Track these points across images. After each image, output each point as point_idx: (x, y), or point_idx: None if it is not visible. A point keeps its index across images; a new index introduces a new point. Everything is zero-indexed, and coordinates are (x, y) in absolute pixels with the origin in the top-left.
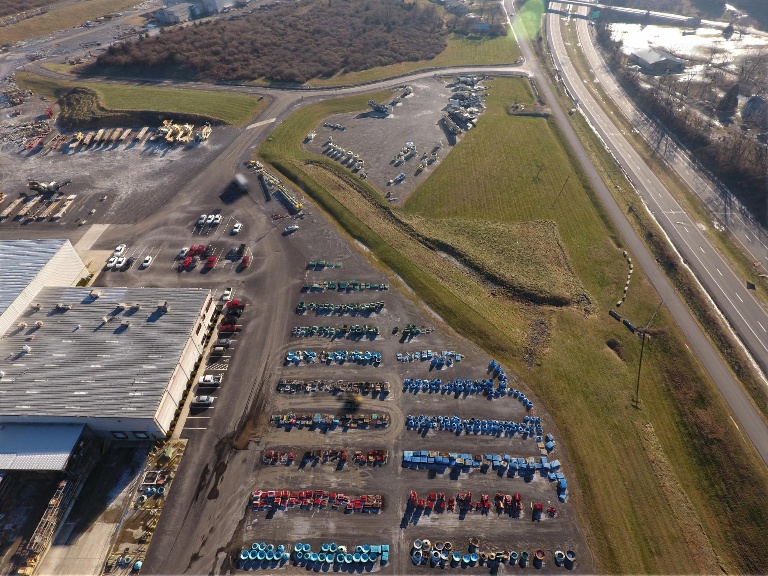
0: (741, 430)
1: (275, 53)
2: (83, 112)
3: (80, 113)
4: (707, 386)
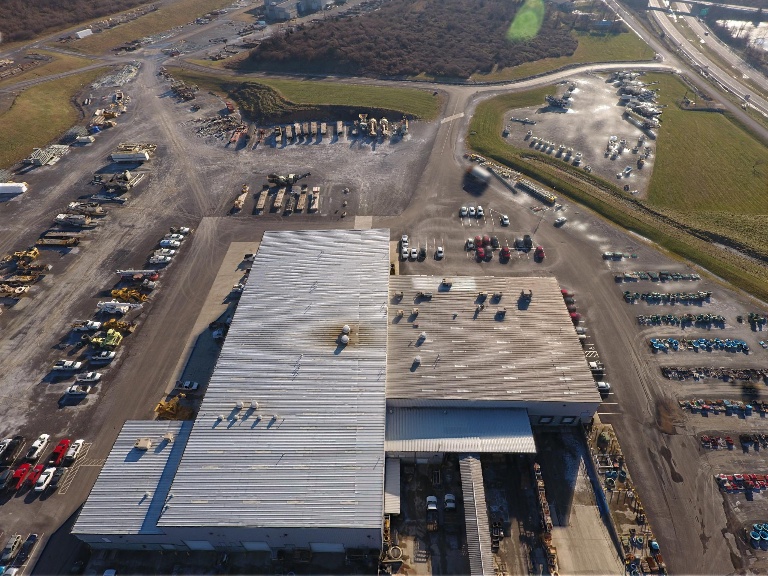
0: None
1: (424, 49)
2: (270, 106)
3: (268, 107)
4: None
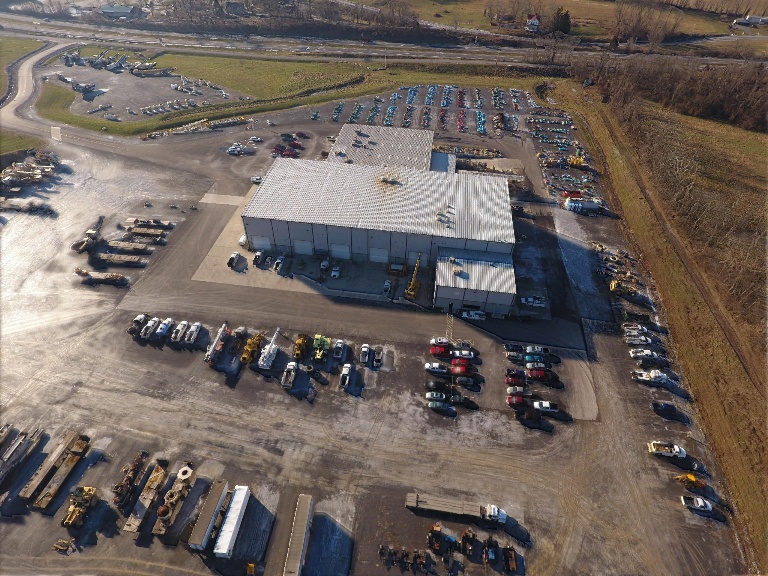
0: (436, 62)
1: None
2: None
3: None
4: (418, 63)
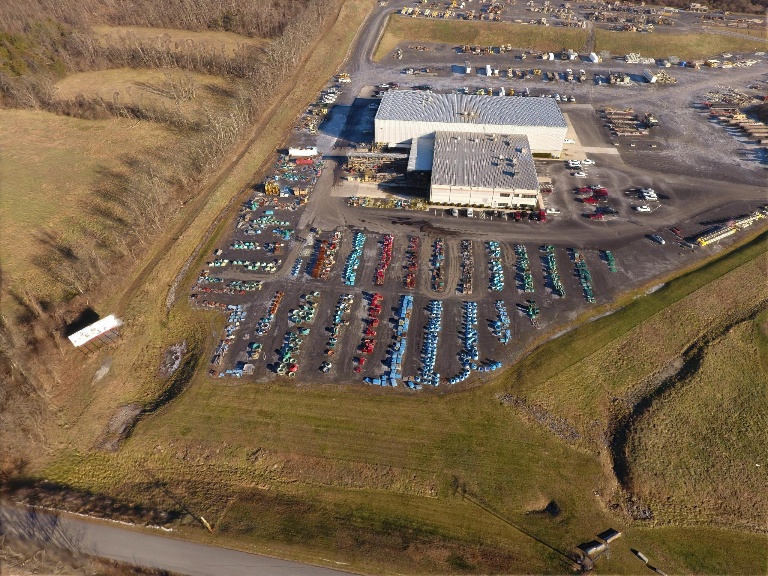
0: None
1: None
2: None
3: None
4: None
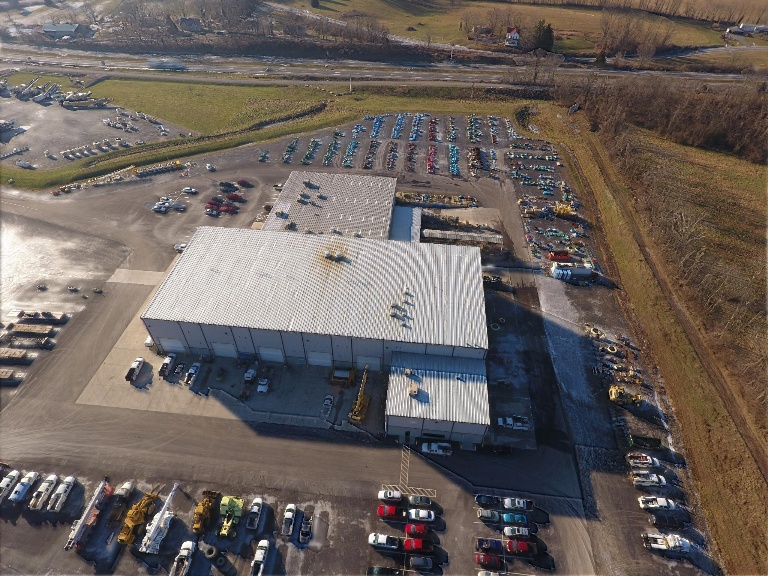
0: None
1: None
2: None
3: None
4: (386, 86)
